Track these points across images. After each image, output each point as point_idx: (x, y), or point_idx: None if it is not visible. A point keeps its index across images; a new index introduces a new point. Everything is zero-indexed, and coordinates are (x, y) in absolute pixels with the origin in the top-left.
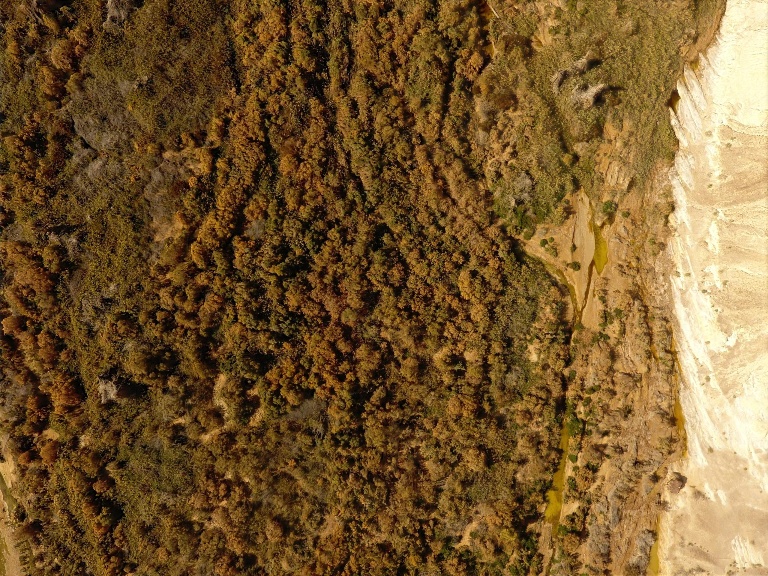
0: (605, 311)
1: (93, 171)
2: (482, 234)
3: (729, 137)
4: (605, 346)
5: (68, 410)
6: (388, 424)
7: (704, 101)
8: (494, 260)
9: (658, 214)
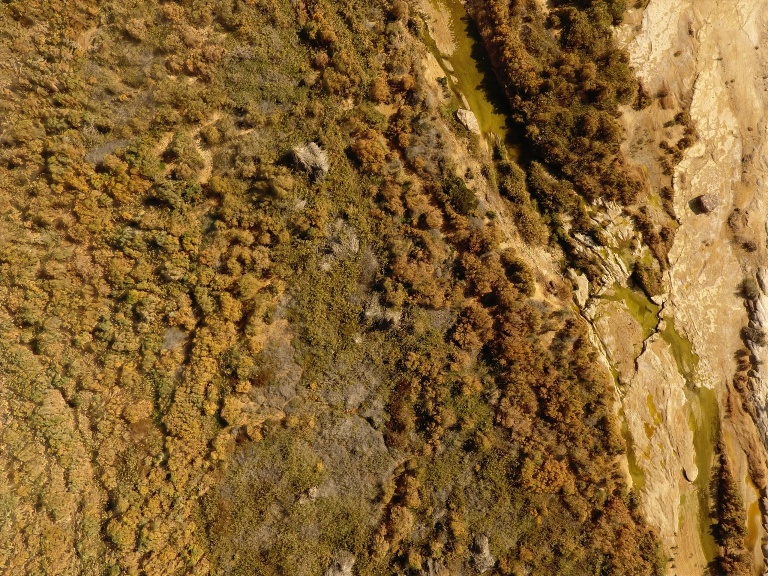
0: None
1: (356, 392)
2: None
3: None
4: None
5: (364, 134)
6: (15, 142)
7: None
8: None
9: None
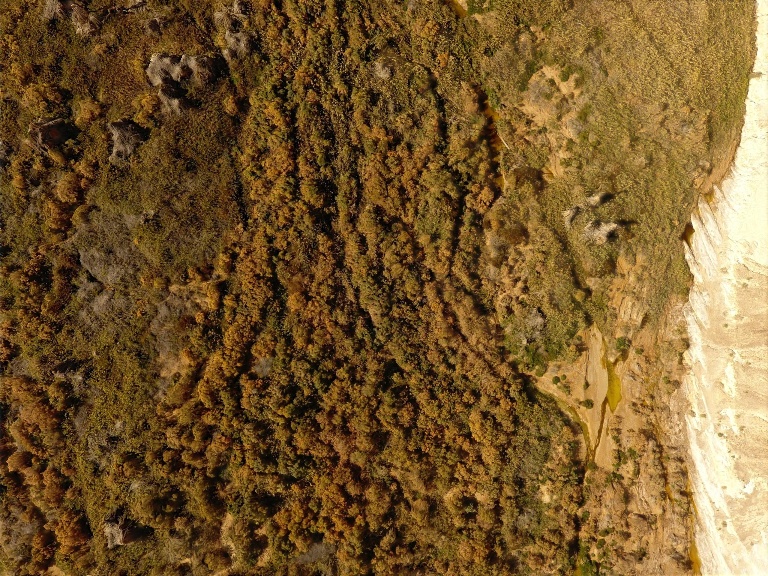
0: (619, 451)
1: (99, 306)
2: (493, 373)
3: (745, 277)
4: (619, 487)
5: (74, 550)
6: (398, 571)
7: (719, 236)
8: (506, 402)
9: (673, 352)
